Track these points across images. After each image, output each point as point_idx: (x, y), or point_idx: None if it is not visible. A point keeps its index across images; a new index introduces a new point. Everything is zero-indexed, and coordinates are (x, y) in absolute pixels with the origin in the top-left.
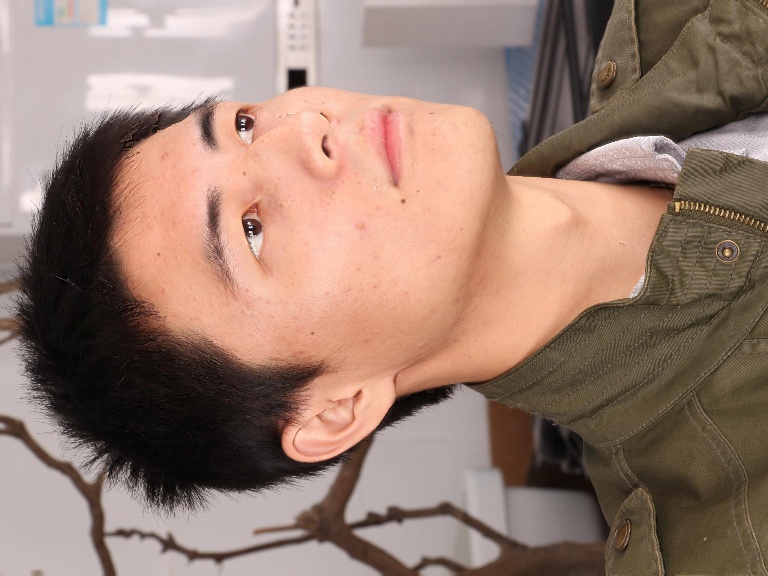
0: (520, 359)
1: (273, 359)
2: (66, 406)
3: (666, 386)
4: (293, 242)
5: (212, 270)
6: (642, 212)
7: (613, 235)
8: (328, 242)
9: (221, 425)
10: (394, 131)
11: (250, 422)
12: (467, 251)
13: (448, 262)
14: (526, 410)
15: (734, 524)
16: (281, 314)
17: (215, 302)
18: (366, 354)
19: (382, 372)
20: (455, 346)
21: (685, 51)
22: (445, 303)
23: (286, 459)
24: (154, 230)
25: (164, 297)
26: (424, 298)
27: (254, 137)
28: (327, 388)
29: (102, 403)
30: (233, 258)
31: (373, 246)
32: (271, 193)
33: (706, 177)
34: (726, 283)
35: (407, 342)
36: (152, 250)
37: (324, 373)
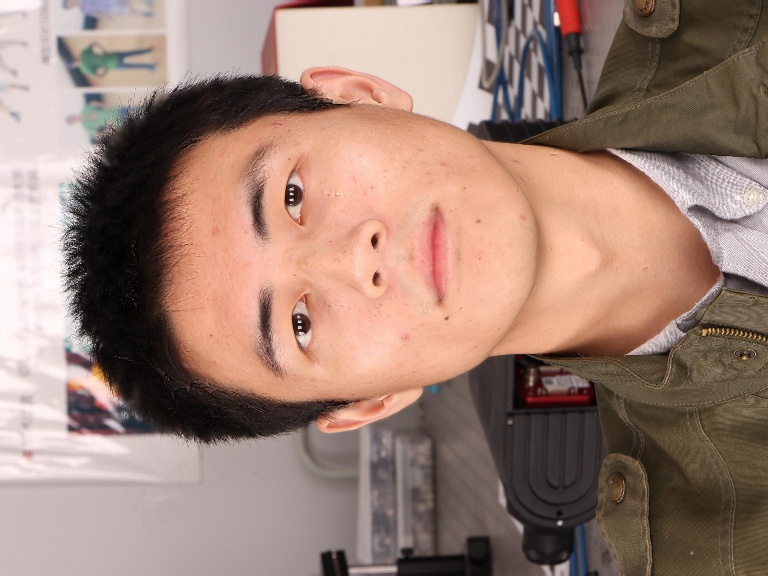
0: (539, 353)
1: (314, 399)
2: (117, 393)
3: (671, 392)
4: (340, 344)
5: None
6: (667, 224)
7: (638, 262)
8: (374, 350)
9: None
10: (442, 261)
11: None
12: (502, 335)
13: (484, 348)
14: None
15: (719, 559)
16: (325, 387)
17: (264, 375)
18: None
19: None
20: None
21: (727, 81)
22: None
23: None
24: (207, 312)
25: (215, 365)
26: (458, 370)
27: (303, 214)
28: None
29: None
30: (283, 358)
31: (415, 348)
32: (320, 292)
33: (735, 307)
34: (740, 374)
35: None
36: (205, 330)
37: None
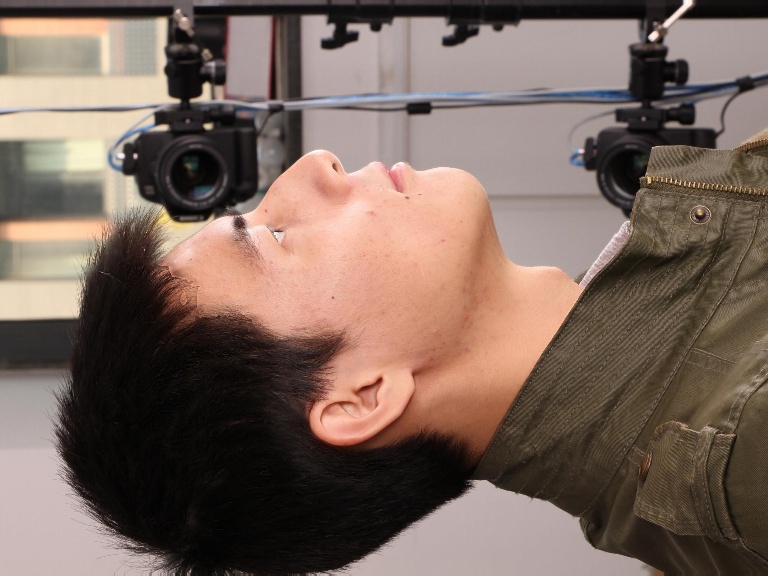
0: (529, 373)
1: (298, 330)
2: (104, 414)
3: (667, 361)
4: (311, 229)
5: (239, 250)
6: None
7: None
8: (342, 221)
9: (251, 392)
10: (395, 165)
11: (279, 398)
12: (468, 244)
13: (452, 246)
14: (542, 453)
15: (744, 354)
16: (303, 281)
17: (243, 280)
18: (384, 329)
19: (400, 360)
20: (467, 357)
21: None
22: (453, 284)
23: (315, 448)
24: (186, 251)
25: (196, 285)
26: (433, 272)
27: None
28: (350, 373)
29: (139, 380)
30: (258, 238)
31: (383, 227)
32: (290, 219)
33: (671, 167)
34: (703, 236)
35: (421, 321)
36: (185, 260)
37: (346, 348)
